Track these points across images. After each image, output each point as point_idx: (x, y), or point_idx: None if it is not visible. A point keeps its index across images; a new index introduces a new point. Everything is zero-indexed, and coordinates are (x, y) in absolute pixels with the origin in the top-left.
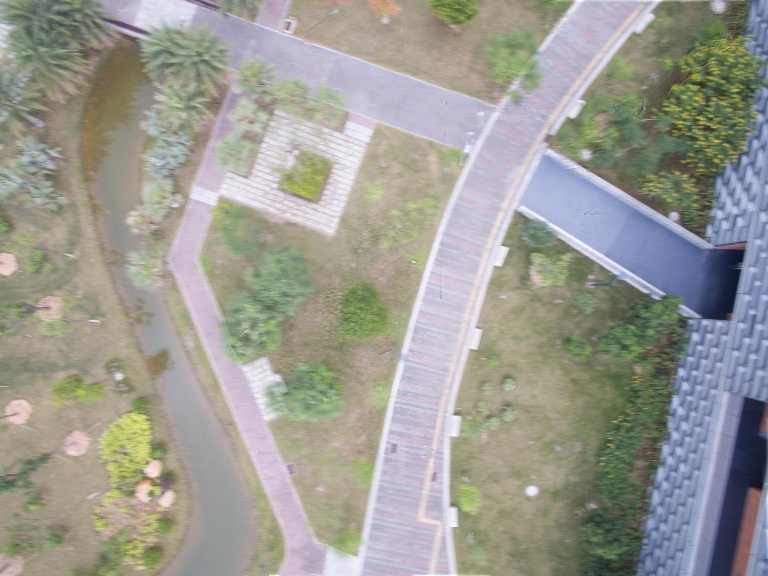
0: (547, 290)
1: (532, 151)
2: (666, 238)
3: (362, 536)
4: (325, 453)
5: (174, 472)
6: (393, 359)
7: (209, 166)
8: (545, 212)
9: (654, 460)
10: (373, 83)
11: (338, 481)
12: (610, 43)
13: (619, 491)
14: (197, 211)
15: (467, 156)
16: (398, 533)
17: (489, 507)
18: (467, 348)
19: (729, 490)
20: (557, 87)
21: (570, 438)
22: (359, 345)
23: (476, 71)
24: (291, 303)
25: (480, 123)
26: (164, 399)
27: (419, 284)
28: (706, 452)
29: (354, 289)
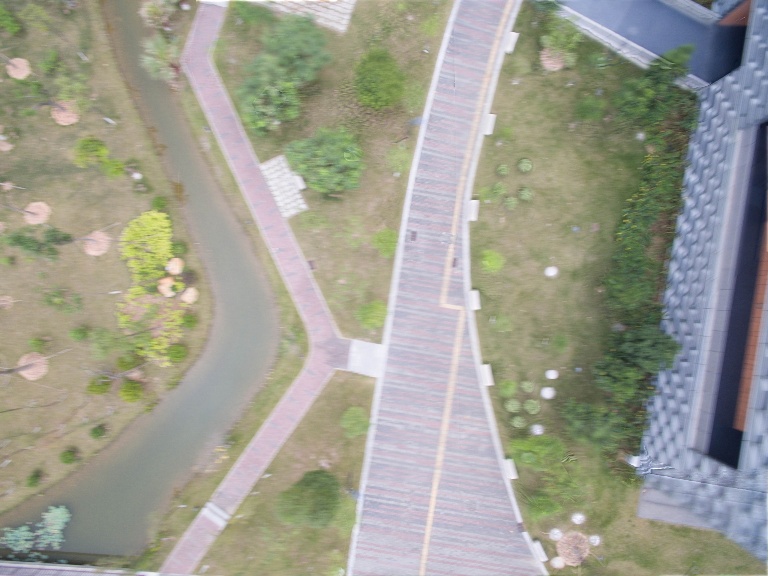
0: (558, 75)
1: None
2: (672, 13)
3: (385, 324)
4: (345, 245)
5: (195, 272)
6: (409, 148)
7: None
8: None
9: (670, 232)
10: None
11: (359, 271)
12: None
13: (637, 264)
14: (209, 13)
15: None
16: (421, 319)
17: (510, 290)
18: (482, 134)
19: (747, 208)
20: None
21: (586, 218)
22: (375, 135)
23: None
24: (306, 100)
25: None
26: (183, 199)
27: (432, 74)
28: (722, 192)
29: (368, 82)
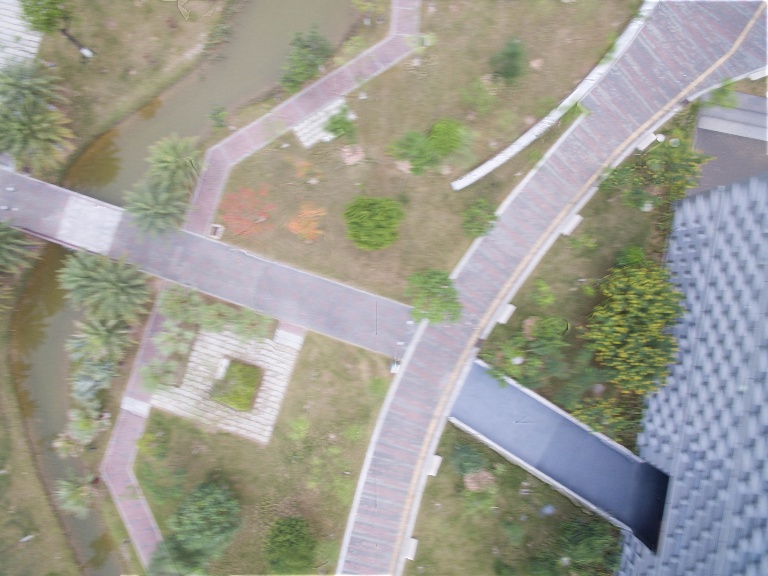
0: (482, 496)
1: (463, 356)
2: (597, 448)
3: None
4: None
5: None
6: (330, 571)
7: (139, 379)
8: (476, 424)
9: None
10: (302, 290)
11: None
12: (539, 244)
13: None
14: (129, 423)
15: (398, 363)
16: None
17: None
18: (403, 557)
19: None
20: (487, 291)
21: None
22: (295, 558)
23: (405, 278)
24: (226, 514)
25: (410, 330)
26: None
27: (354, 494)
28: None
29: (289, 500)
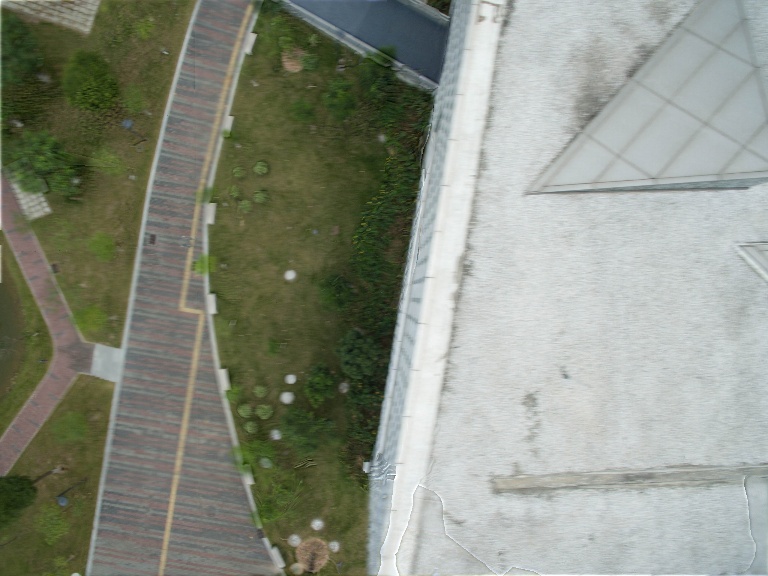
0: (300, 76)
1: None
2: (407, 13)
3: (124, 328)
4: (86, 248)
5: None
6: (149, 150)
7: None
8: None
9: (405, 235)
10: None
11: (99, 275)
12: None
13: (373, 268)
14: None
15: None
16: (160, 323)
17: (249, 293)
18: (222, 136)
19: None
20: None
21: (326, 221)
22: (114, 138)
23: None
24: (49, 102)
25: None
26: None
27: (173, 76)
28: None
29: (109, 84)
